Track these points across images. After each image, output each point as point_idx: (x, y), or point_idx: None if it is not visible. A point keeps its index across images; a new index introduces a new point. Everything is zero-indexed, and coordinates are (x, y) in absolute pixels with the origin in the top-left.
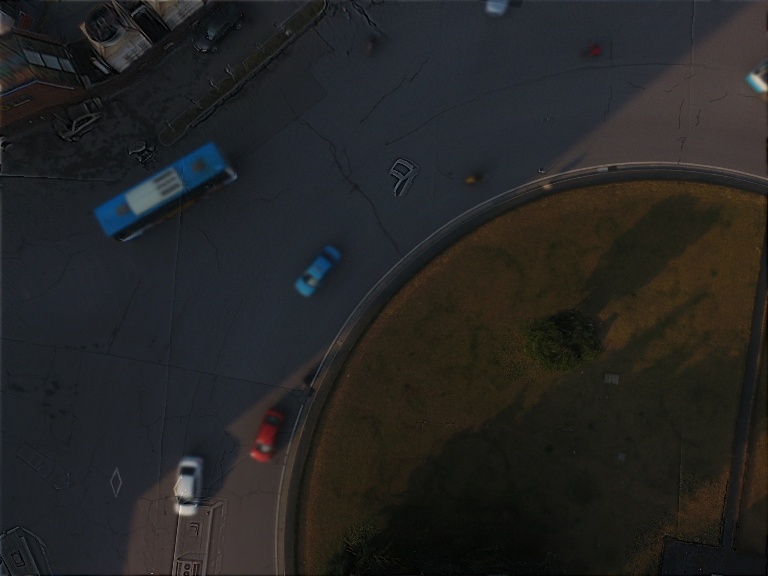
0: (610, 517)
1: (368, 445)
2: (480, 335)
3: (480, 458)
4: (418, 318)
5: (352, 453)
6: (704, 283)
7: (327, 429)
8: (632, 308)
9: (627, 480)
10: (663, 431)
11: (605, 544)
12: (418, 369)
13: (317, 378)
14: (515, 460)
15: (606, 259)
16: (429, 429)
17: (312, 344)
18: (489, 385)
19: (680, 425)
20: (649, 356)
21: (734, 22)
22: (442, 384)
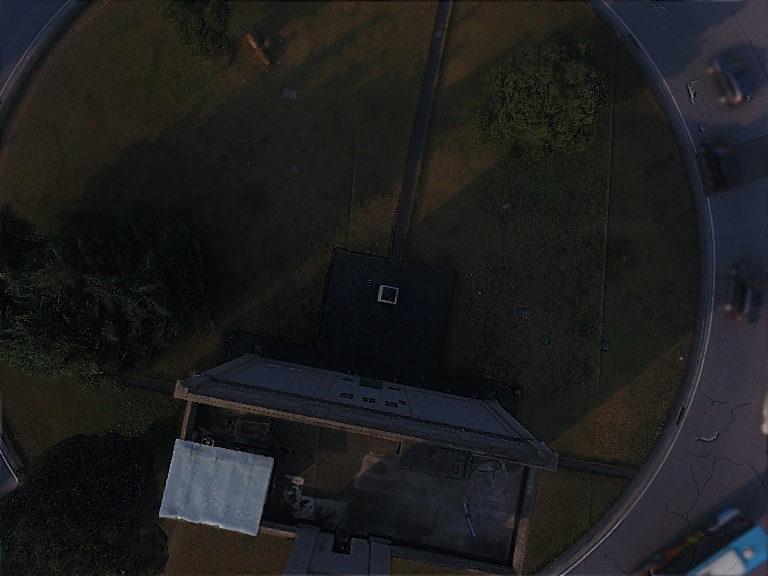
0: (280, 226)
1: (48, 153)
2: (162, 49)
3: (156, 167)
4: (104, 33)
5: (32, 161)
6: (384, 4)
7: (10, 138)
8: (312, 26)
9: (299, 191)
10: (337, 145)
11: (275, 252)
12: (101, 81)
13: (5, 91)
14: (190, 169)
15: None
16: (108, 138)
17: (2, 58)
18: (168, 97)
19: (354, 139)
20: (326, 72)
21: None
22: (122, 95)
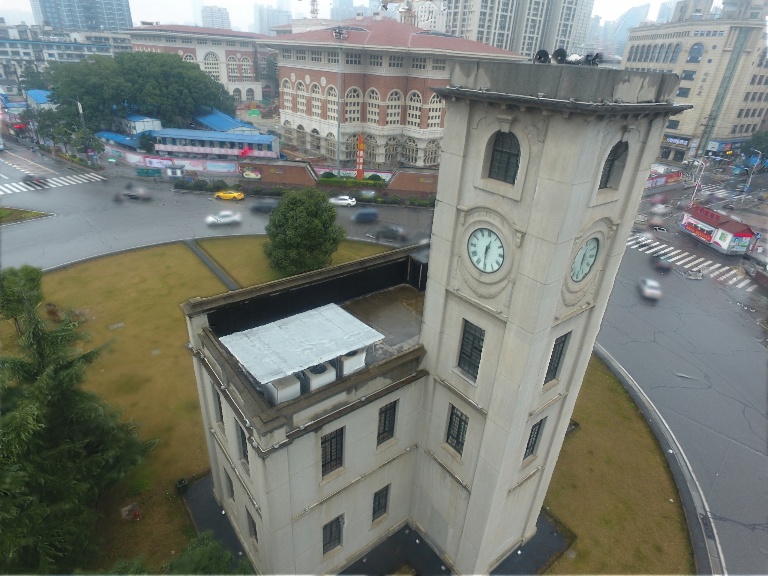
0: (170, 385)
1: None
2: None
3: None
4: None
5: None
6: (164, 271)
7: None
8: None
9: (172, 360)
10: (184, 326)
11: (179, 403)
12: None
13: None
14: None
15: (75, 289)
16: None
17: None
18: None
19: None
20: (143, 305)
21: (117, 217)
22: None
